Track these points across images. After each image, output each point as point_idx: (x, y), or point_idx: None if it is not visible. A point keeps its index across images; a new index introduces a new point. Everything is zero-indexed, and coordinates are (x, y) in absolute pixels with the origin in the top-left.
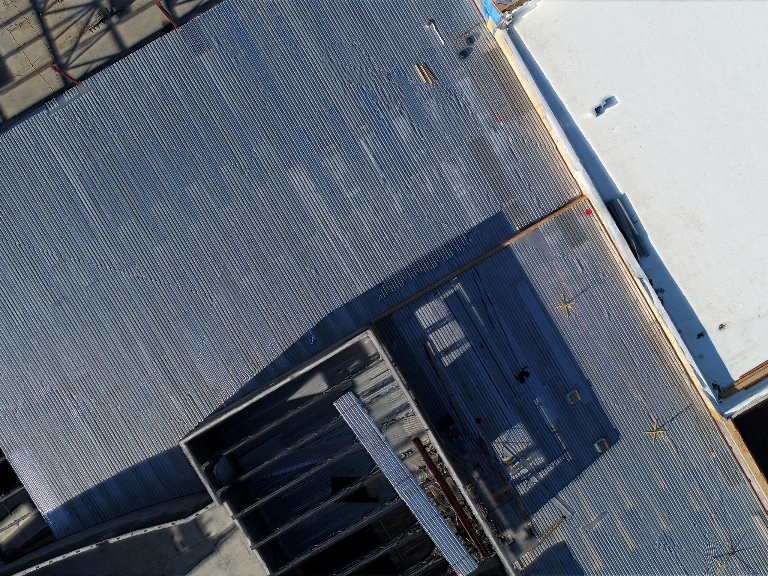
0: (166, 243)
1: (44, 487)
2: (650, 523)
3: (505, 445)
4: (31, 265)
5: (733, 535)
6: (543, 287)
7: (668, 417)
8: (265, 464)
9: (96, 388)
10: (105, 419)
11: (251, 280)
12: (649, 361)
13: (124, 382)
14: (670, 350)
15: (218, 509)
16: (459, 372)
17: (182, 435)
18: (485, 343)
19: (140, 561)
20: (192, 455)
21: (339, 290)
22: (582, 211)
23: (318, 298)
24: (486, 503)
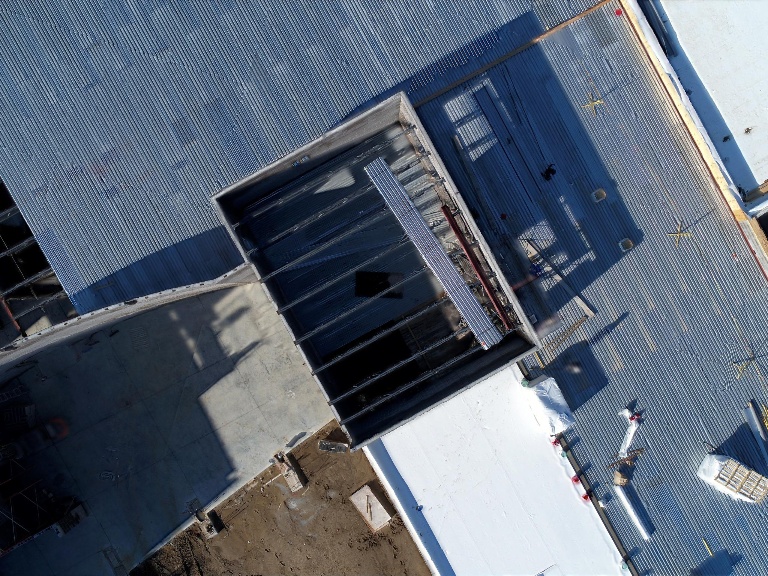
0: (200, 30)
1: (71, 268)
2: (672, 325)
3: (530, 242)
4: (66, 47)
5: (754, 340)
6: (571, 85)
7: (692, 220)
8: (294, 227)
9: (126, 172)
10: (134, 203)
11: (282, 70)
12: (675, 163)
13: (154, 167)
14: (696, 153)
15: (238, 328)
16: (486, 167)
17: (209, 222)
18: (512, 139)
19: (159, 377)
20: (223, 211)
21: (369, 83)
22: (612, 11)
23: (348, 90)
24: (511, 282)
